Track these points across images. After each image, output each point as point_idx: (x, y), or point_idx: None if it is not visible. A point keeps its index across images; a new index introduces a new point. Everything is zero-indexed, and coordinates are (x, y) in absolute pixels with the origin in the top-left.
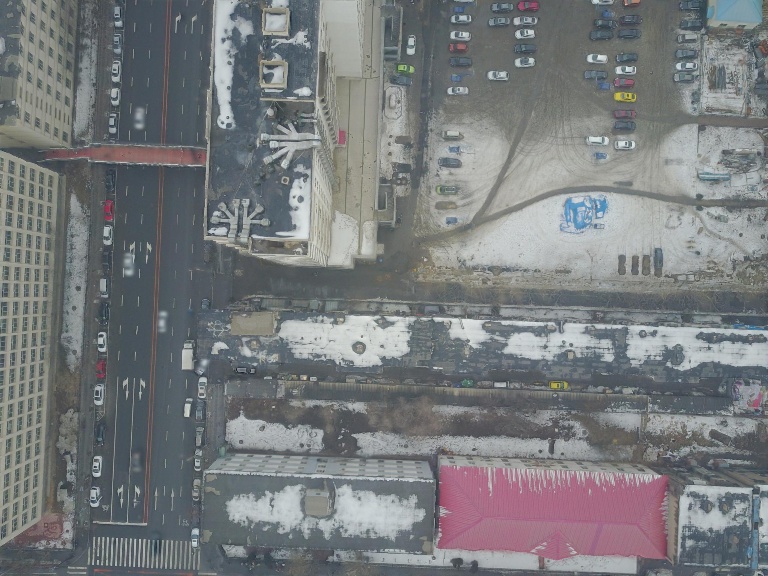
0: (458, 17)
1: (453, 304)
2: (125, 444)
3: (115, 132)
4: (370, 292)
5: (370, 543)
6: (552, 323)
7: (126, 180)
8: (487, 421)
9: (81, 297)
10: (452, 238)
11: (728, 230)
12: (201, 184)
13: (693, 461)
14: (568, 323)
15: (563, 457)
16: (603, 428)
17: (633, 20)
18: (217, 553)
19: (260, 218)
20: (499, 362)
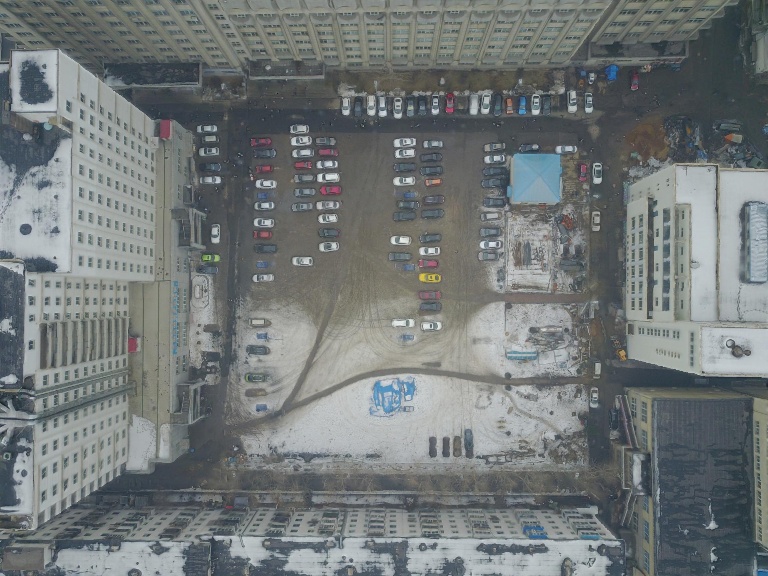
0: (260, 205)
1: (265, 492)
2: None
3: None
4: (183, 482)
5: None
6: (332, 538)
7: None
8: None
9: None
10: (263, 425)
11: (538, 409)
12: None
13: None
14: (348, 538)
15: None
16: None
17: (434, 201)
18: None
19: None
20: None
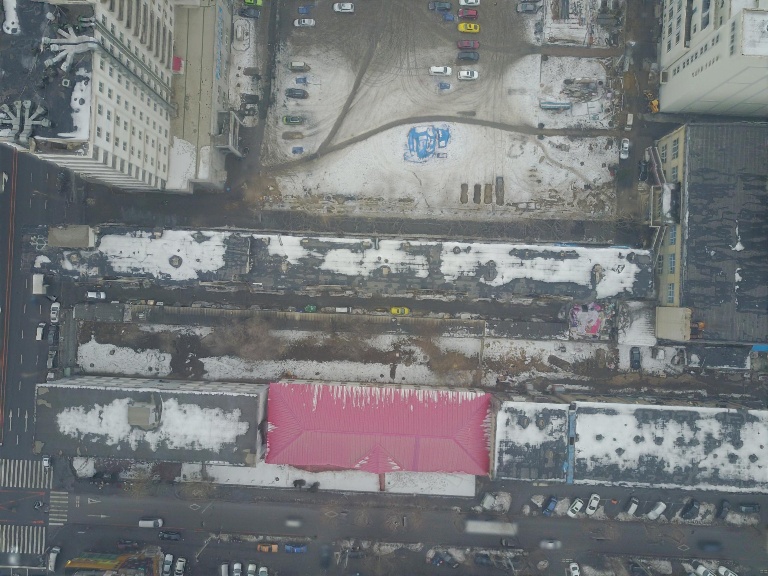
0: None
1: (298, 232)
2: None
3: None
4: (218, 220)
5: (195, 455)
6: (368, 240)
7: None
8: None
9: None
10: (298, 167)
11: (569, 159)
12: None
13: (530, 385)
14: (384, 240)
15: (404, 382)
16: (444, 353)
17: None
18: (69, 473)
19: None
20: (316, 278)
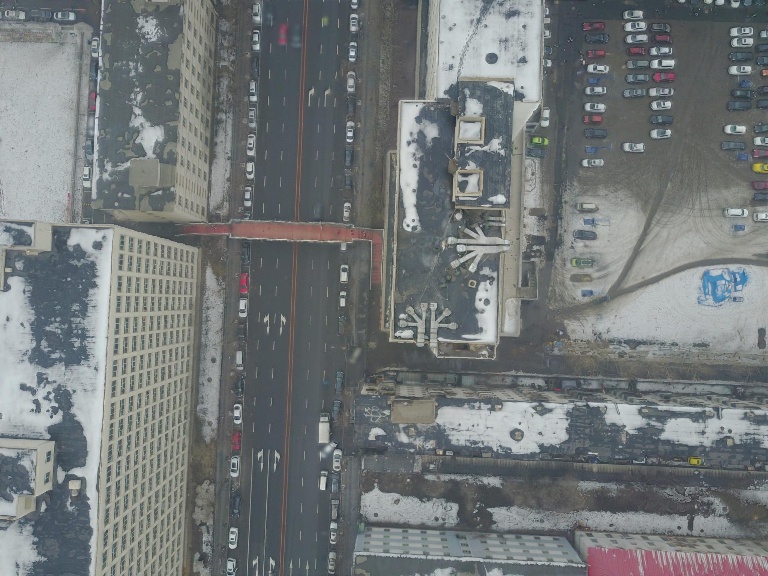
0: (593, 89)
1: (589, 378)
2: (260, 515)
3: (250, 205)
4: (504, 365)
5: None
6: (710, 409)
7: (260, 252)
8: (624, 497)
9: (216, 369)
10: (587, 311)
11: None
12: (334, 256)
13: None
14: (726, 409)
15: (703, 534)
16: (744, 505)
17: None
18: None
19: (446, 321)
20: (656, 448)
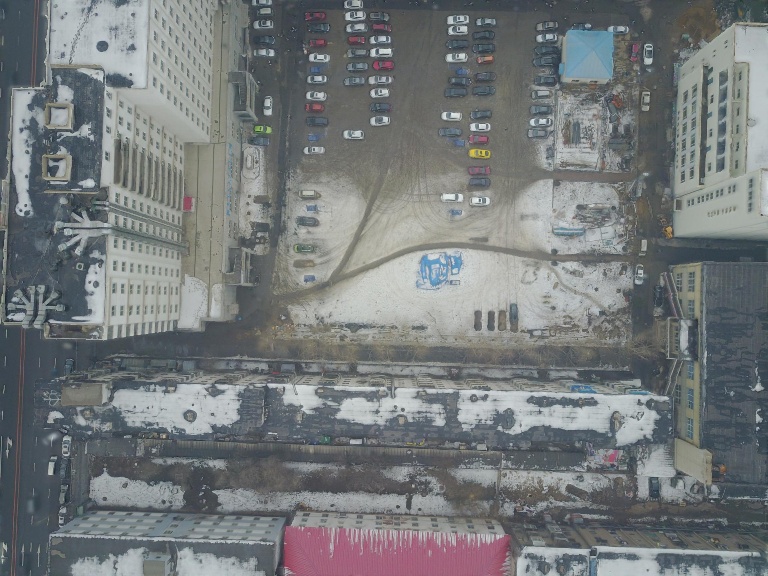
0: (313, 78)
1: (311, 361)
2: None
3: None
4: (230, 350)
5: None
6: (384, 388)
7: None
8: (345, 477)
9: None
10: (310, 296)
11: (583, 285)
12: None
13: (548, 517)
14: (400, 388)
15: (420, 512)
16: (460, 483)
17: (486, 77)
18: None
19: (57, 303)
20: (332, 427)
